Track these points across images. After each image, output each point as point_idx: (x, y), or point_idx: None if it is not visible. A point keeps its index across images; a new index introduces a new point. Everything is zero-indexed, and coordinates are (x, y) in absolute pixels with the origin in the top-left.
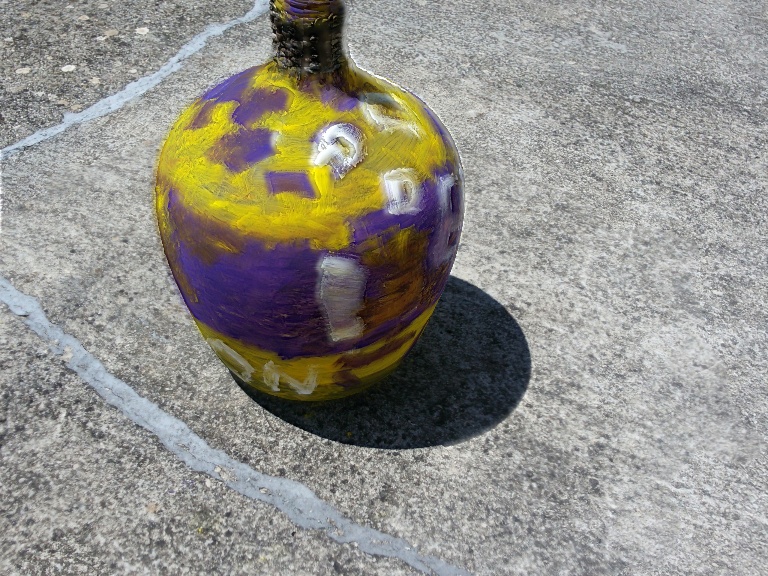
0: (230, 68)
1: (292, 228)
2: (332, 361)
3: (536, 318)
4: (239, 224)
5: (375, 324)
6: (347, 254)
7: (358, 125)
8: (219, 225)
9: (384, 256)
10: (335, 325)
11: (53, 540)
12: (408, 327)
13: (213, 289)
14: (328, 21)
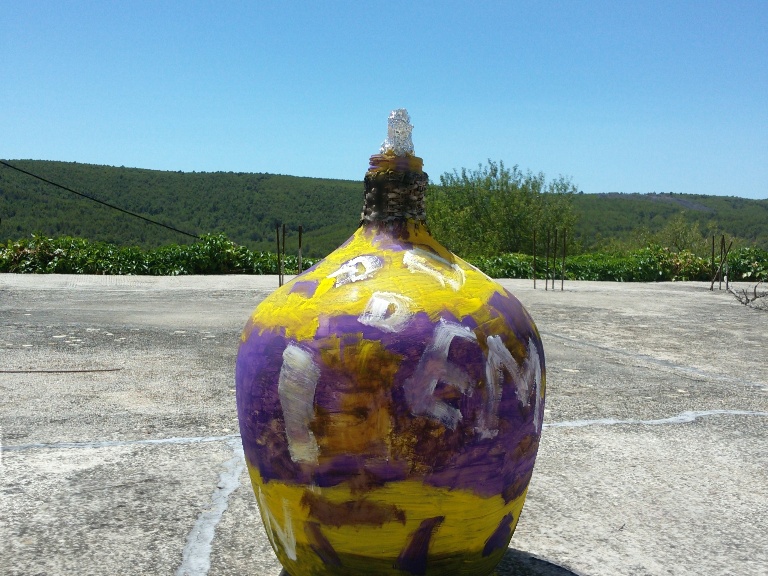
0: (588, 439)
1: (278, 318)
2: (298, 498)
3: None
4: None
5: (330, 452)
6: (304, 346)
7: (383, 259)
8: None
9: (338, 360)
10: (291, 435)
11: (34, 575)
12: (383, 490)
13: None
14: (385, 175)
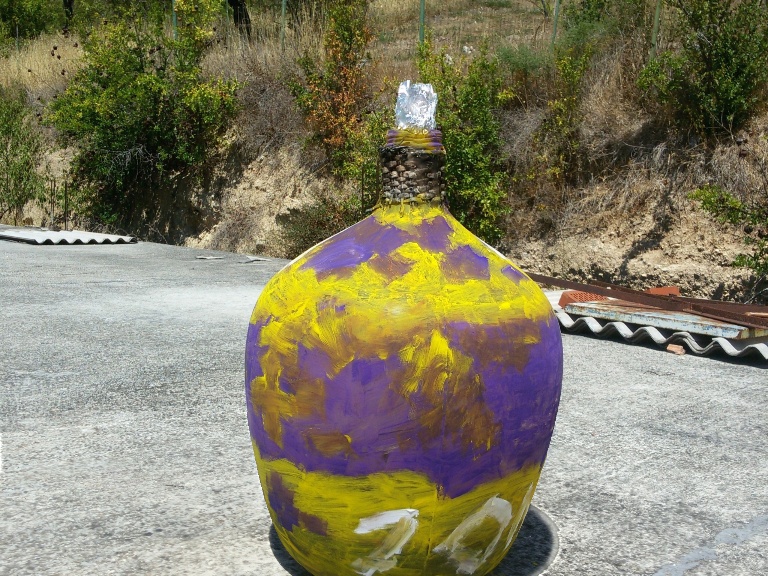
0: None
1: (543, 305)
2: None
3: None
4: (527, 315)
5: None
6: None
7: None
8: (517, 324)
9: None
10: None
11: None
12: None
13: (519, 405)
14: None
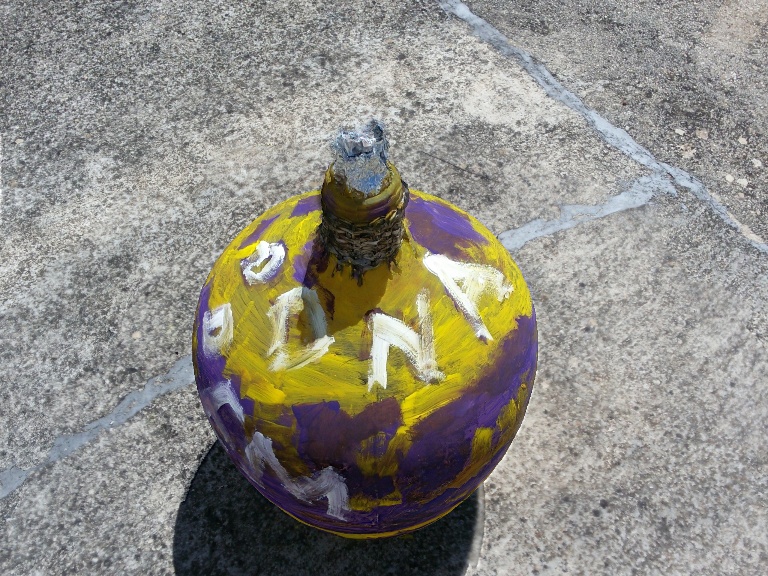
0: None
1: None
2: None
3: None
4: None
5: None
6: None
7: (278, 275)
8: None
9: None
10: None
11: None
12: None
13: None
14: None
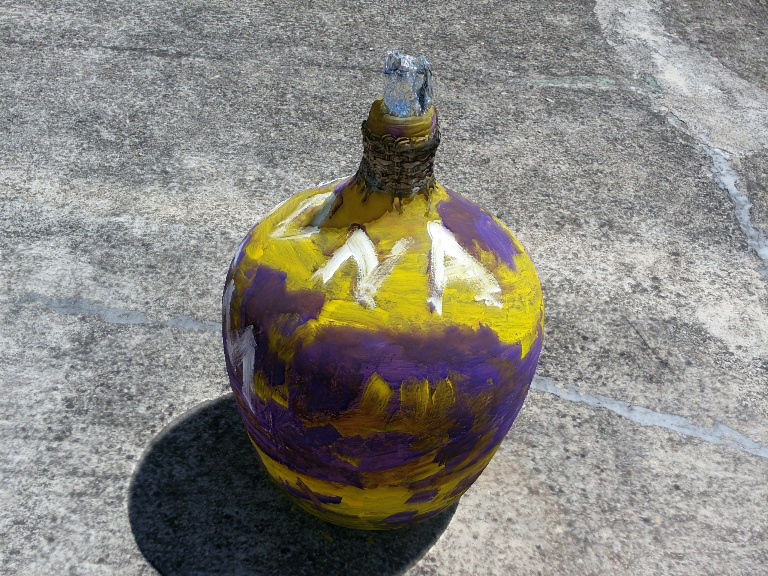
0: None
1: None
2: None
3: (120, 574)
4: None
5: None
6: None
7: None
8: None
9: None
10: None
11: None
12: None
13: None
14: None
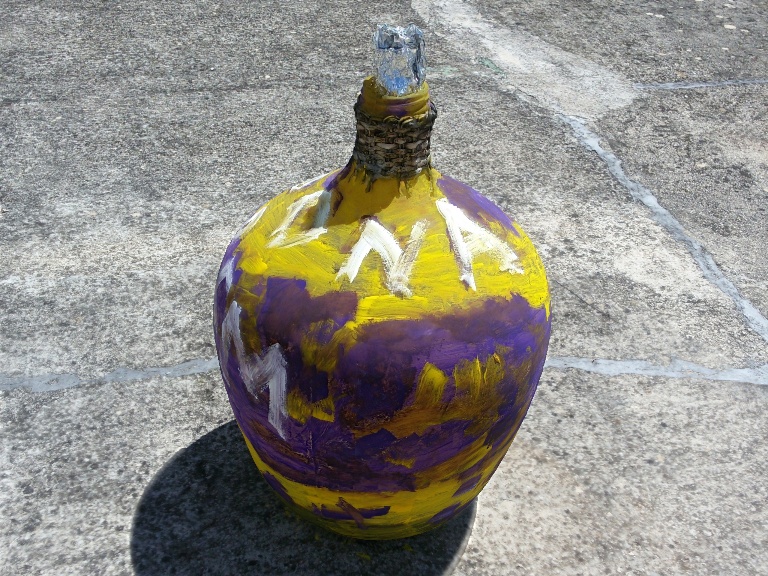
0: None
1: None
2: None
3: None
4: None
5: None
6: None
7: None
8: None
9: None
10: None
11: None
12: None
13: None
14: None
